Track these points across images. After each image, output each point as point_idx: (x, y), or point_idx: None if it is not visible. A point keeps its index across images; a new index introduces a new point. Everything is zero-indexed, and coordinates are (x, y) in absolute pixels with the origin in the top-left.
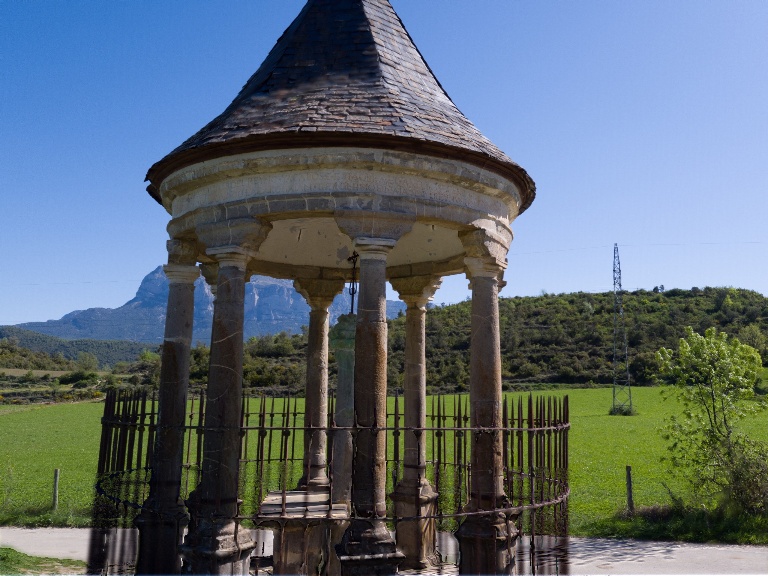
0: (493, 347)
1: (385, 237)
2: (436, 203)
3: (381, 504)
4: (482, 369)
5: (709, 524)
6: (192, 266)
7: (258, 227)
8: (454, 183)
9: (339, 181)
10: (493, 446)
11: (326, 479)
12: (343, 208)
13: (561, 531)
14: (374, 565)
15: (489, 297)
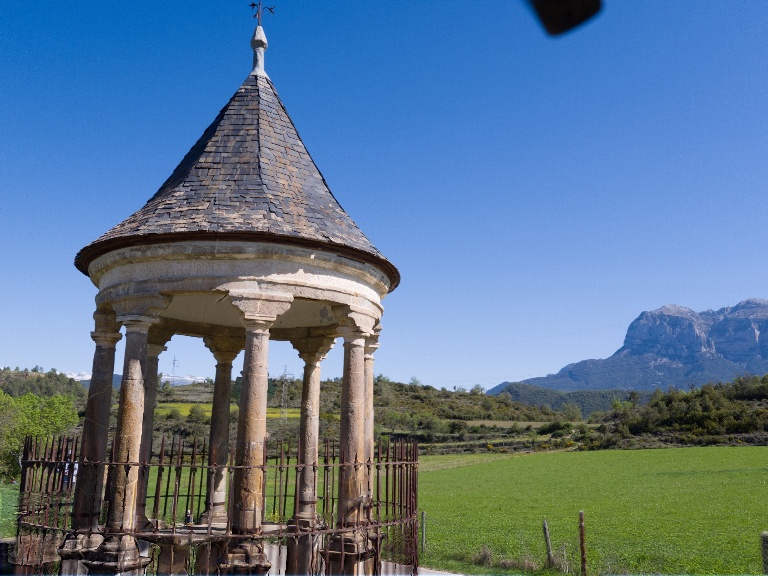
0: (248, 393)
1: None
2: (174, 279)
3: (119, 523)
4: (240, 414)
5: None
6: None
7: (103, 316)
8: (197, 259)
9: (117, 276)
10: (242, 483)
11: (311, 514)
12: None
13: None
14: (102, 570)
15: (249, 349)
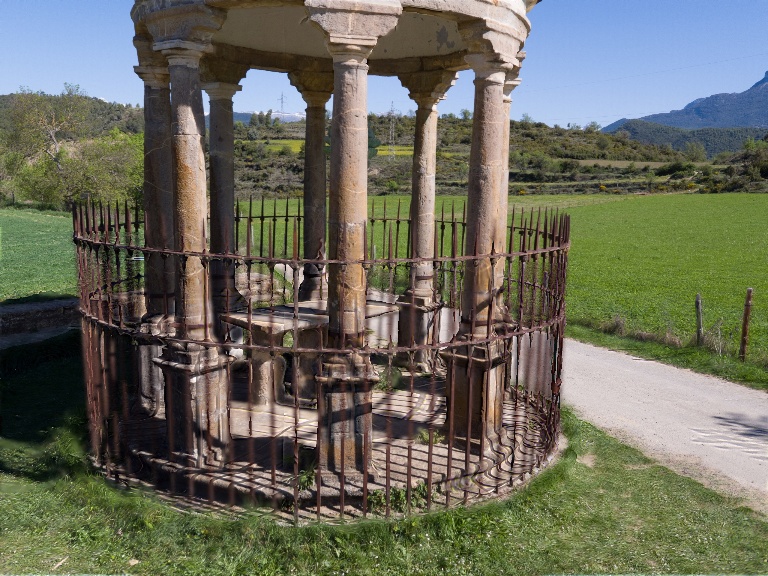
0: (340, 155)
1: (174, 38)
2: None
3: (189, 318)
4: None
5: None
6: (215, 83)
7: (145, 44)
8: None
9: None
10: (337, 276)
11: (426, 291)
12: (151, 12)
13: None
14: (175, 371)
15: (339, 89)
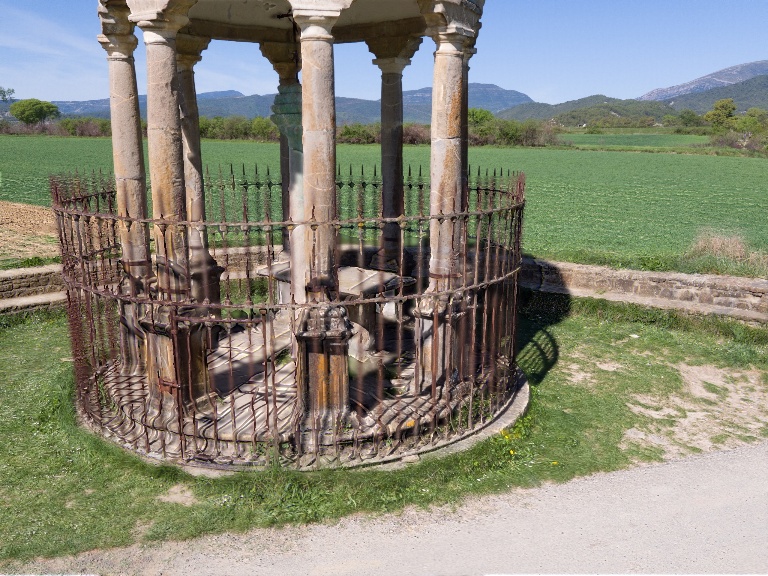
0: None
1: None
2: None
3: None
4: None
5: None
6: None
7: None
8: None
9: None
10: None
11: None
12: None
13: None
14: None
15: None
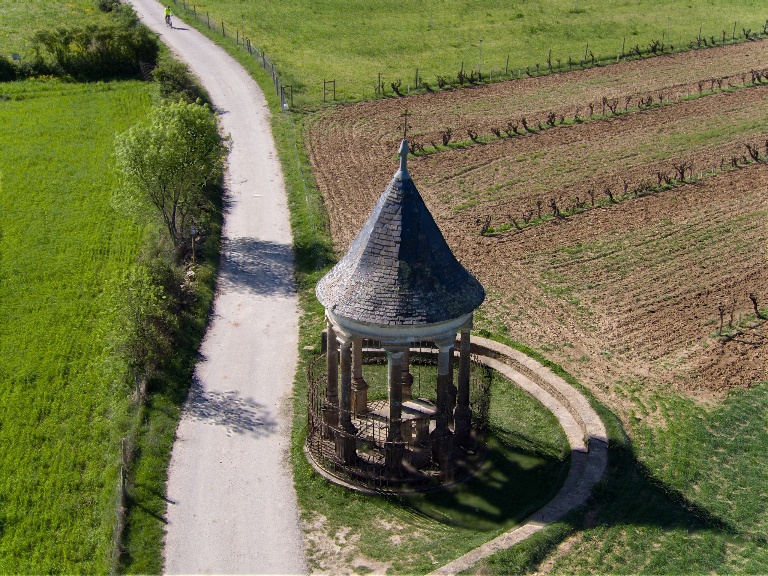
0: None
1: None
2: None
3: None
4: None
5: (172, 376)
6: None
7: None
8: None
9: None
10: None
11: None
12: None
13: (171, 424)
14: None
15: None
